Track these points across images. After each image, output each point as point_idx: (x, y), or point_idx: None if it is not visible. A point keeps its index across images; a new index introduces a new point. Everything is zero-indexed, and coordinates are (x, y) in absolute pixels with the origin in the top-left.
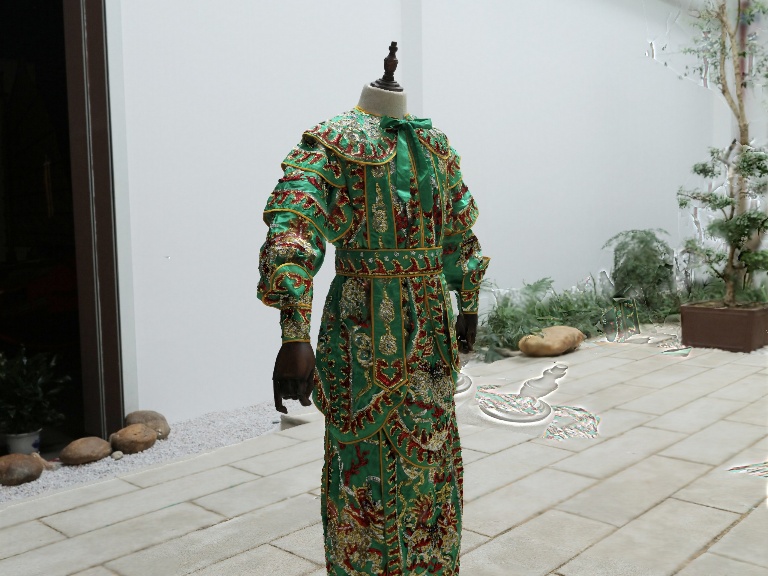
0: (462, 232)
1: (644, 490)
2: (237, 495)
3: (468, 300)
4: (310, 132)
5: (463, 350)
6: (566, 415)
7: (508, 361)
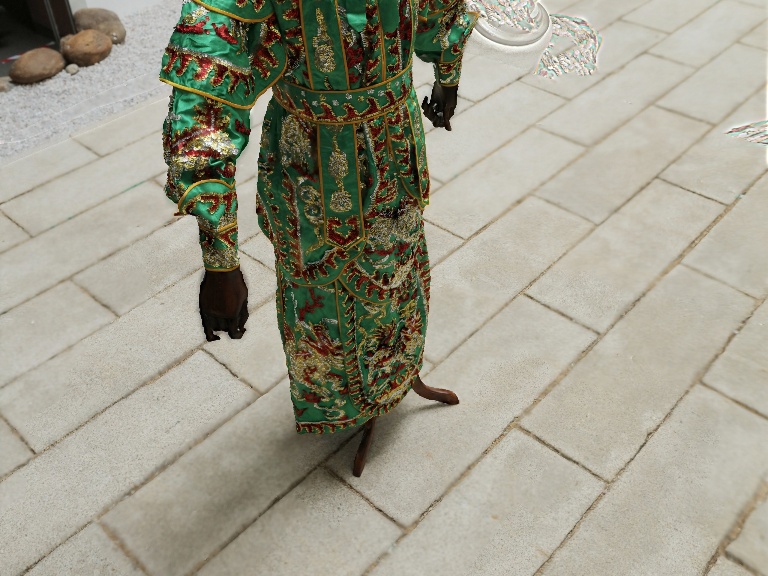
0: None
1: (632, 166)
2: None
3: (448, 73)
4: None
5: (439, 125)
6: (565, 33)
7: None
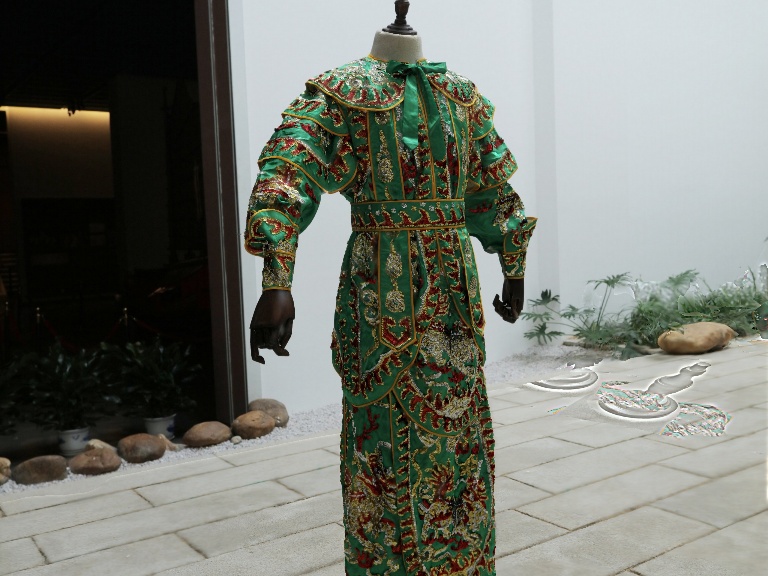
0: (497, 188)
1: (761, 491)
2: (322, 476)
3: (511, 263)
4: (312, 80)
5: (508, 318)
6: (693, 412)
7: (644, 358)
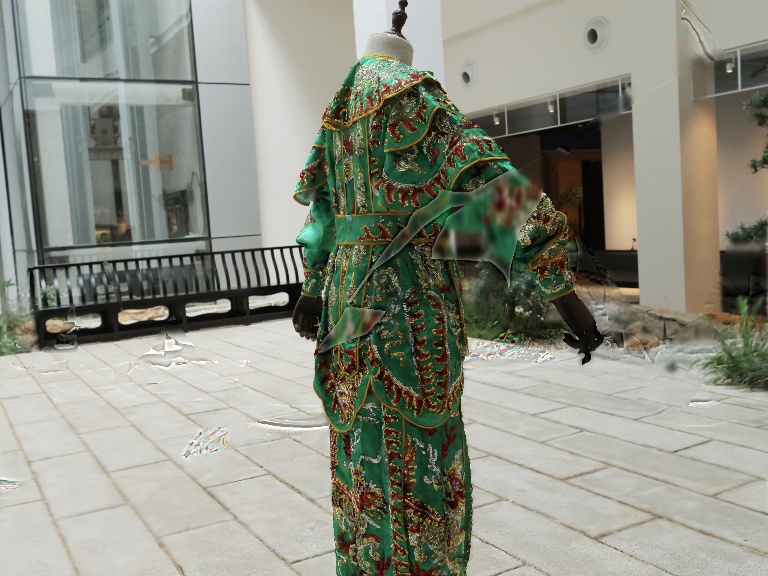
0: None
1: (179, 493)
2: None
3: None
4: None
5: None
6: None
7: None
